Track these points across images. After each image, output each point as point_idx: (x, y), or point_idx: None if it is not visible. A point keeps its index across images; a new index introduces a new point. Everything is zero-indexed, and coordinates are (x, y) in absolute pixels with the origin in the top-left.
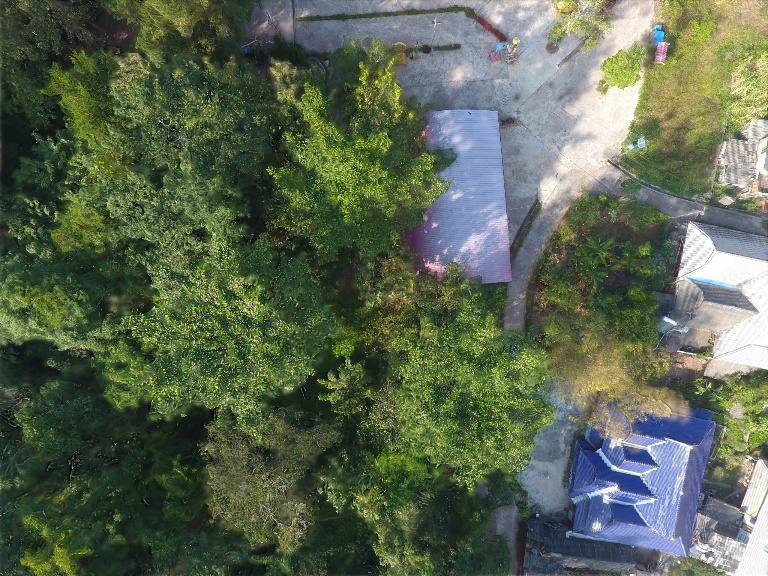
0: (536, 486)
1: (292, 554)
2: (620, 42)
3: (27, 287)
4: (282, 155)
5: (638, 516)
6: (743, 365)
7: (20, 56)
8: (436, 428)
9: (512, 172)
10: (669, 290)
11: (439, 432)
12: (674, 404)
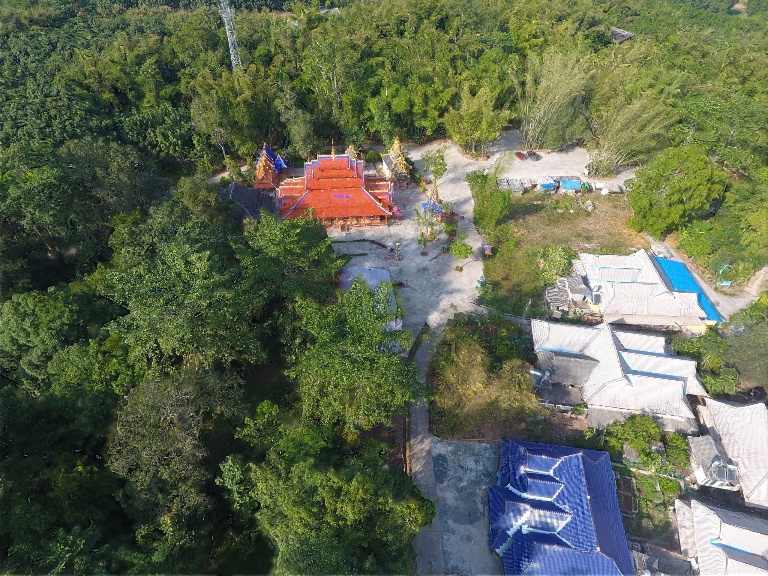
0: (461, 554)
1: (169, 563)
2: None
3: (40, 295)
4: (241, 267)
5: (561, 540)
6: (616, 413)
7: (94, 227)
8: (319, 334)
9: (406, 310)
10: (537, 368)
11: (321, 335)
12: None
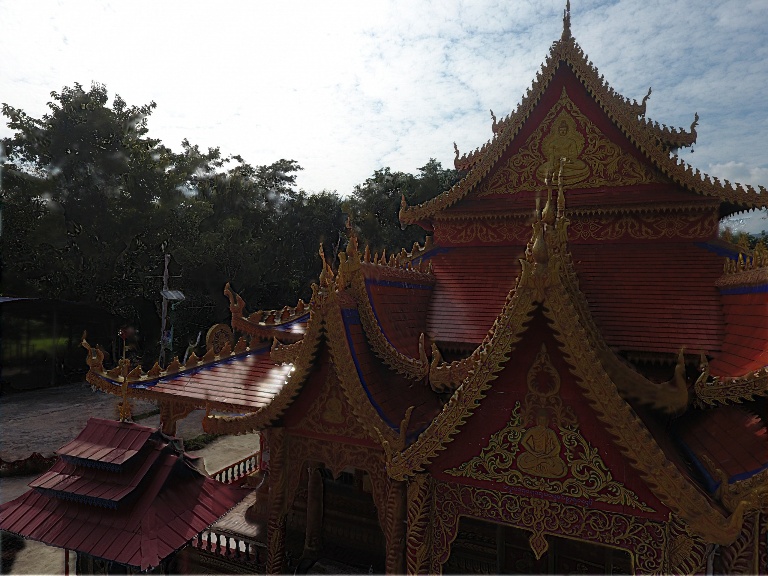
0: None
1: None
2: None
3: None
4: None
5: None
6: None
7: None
8: None
9: None
10: None
11: None
12: None
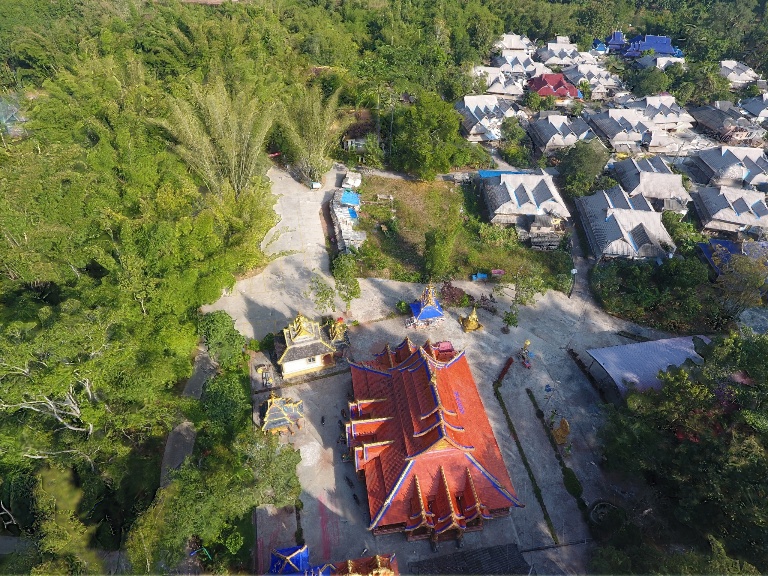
0: None
1: None
2: (487, 295)
3: None
4: None
5: None
6: None
7: None
8: None
9: None
10: None
11: None
12: (701, 261)
